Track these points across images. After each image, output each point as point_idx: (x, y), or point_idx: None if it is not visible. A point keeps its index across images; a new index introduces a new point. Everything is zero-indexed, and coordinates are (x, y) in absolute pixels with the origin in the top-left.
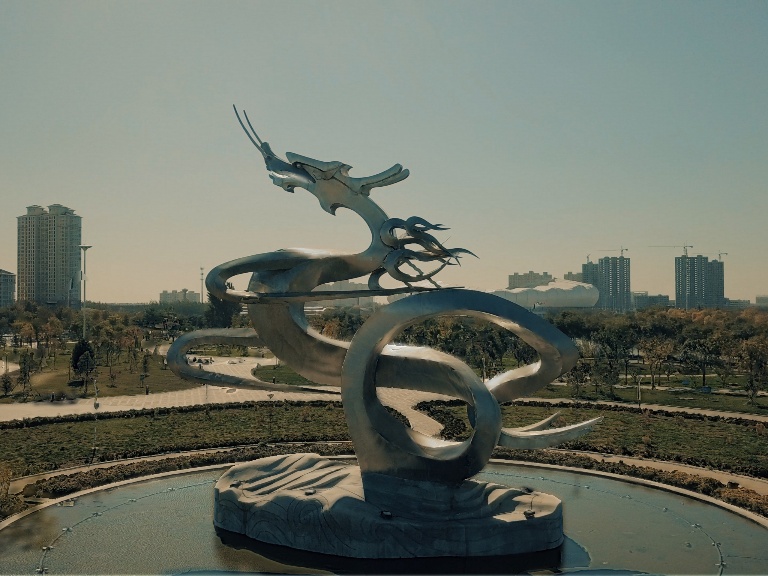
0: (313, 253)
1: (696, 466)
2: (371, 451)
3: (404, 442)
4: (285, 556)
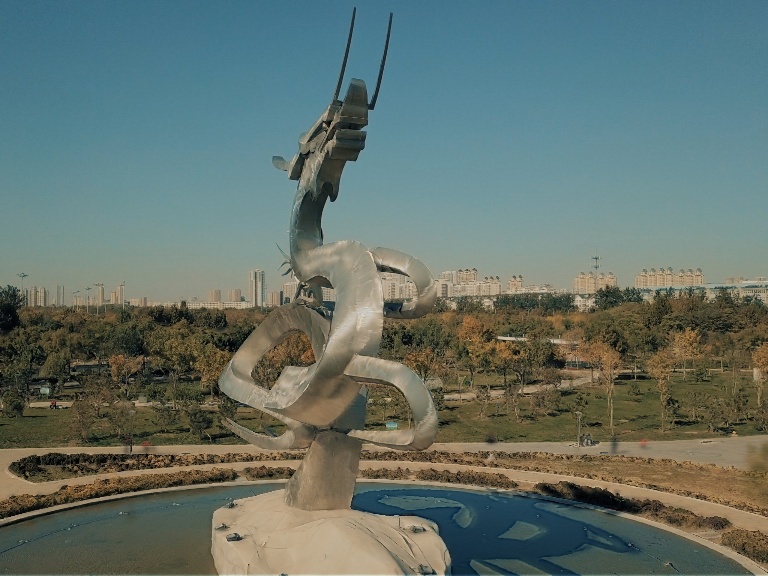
0: None
1: None
2: None
3: None
4: None
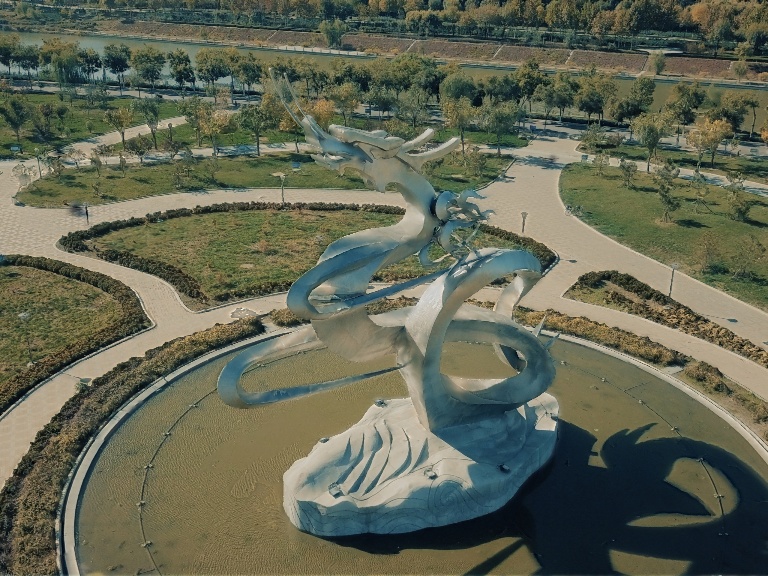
0: (379, 242)
1: None
2: (442, 413)
3: (463, 395)
4: (445, 539)
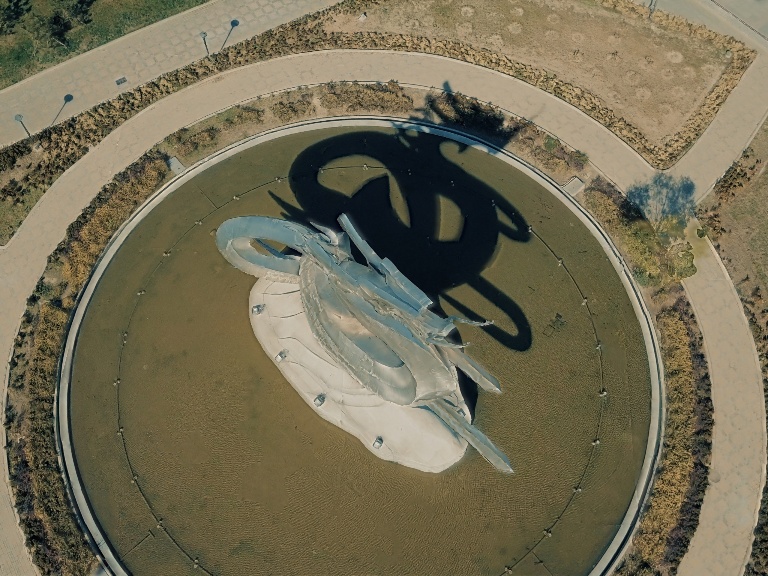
0: None
1: None
2: None
3: None
4: None
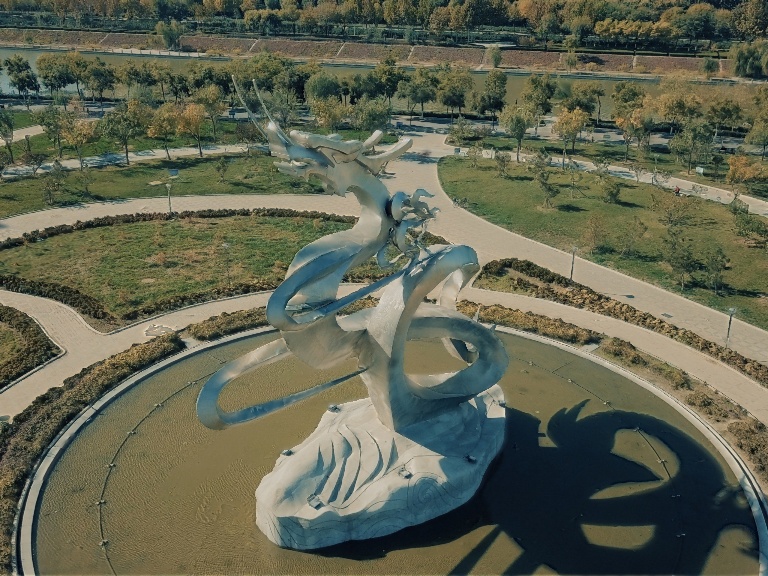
0: (344, 247)
1: (357, 283)
2: None
3: (422, 392)
4: (426, 536)
